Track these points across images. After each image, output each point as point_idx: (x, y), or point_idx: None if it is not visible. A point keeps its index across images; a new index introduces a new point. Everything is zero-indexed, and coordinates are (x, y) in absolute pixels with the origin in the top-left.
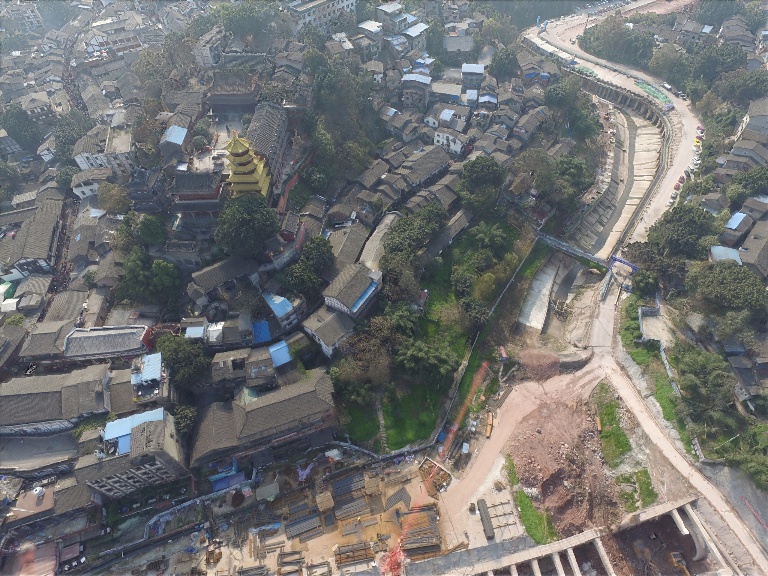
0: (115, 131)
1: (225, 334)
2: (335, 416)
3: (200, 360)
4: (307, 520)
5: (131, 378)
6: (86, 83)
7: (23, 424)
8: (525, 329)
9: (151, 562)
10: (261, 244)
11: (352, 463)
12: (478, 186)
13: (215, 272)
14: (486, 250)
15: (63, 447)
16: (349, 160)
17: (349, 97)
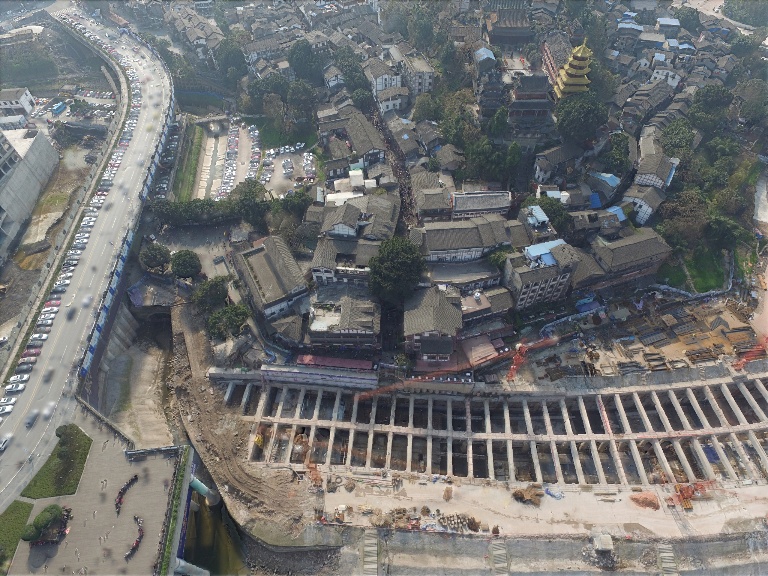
0: (410, 58)
1: (572, 199)
2: (662, 262)
3: (567, 213)
4: (655, 334)
5: (529, 219)
6: (330, 29)
7: (454, 250)
8: (758, 223)
9: (548, 357)
10: (595, 131)
11: (674, 299)
12: (712, 108)
13: (558, 152)
14: (729, 156)
15: (479, 270)
16: (607, 84)
17: (599, 34)
